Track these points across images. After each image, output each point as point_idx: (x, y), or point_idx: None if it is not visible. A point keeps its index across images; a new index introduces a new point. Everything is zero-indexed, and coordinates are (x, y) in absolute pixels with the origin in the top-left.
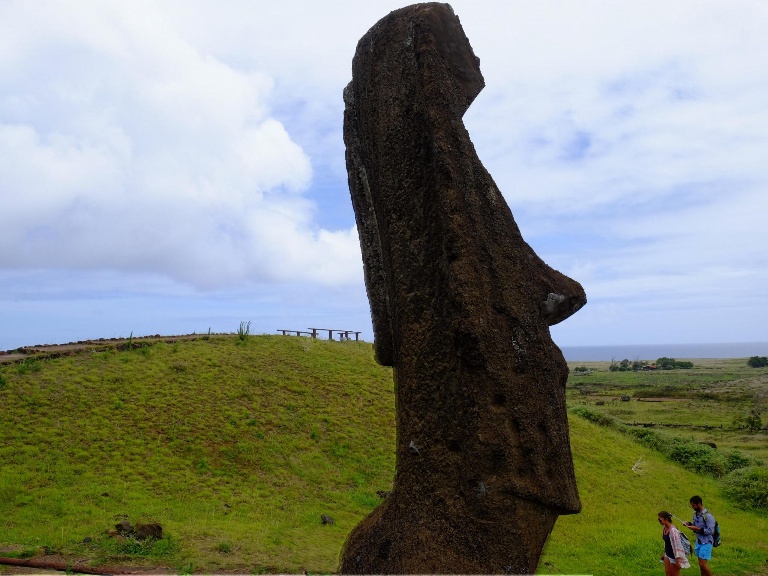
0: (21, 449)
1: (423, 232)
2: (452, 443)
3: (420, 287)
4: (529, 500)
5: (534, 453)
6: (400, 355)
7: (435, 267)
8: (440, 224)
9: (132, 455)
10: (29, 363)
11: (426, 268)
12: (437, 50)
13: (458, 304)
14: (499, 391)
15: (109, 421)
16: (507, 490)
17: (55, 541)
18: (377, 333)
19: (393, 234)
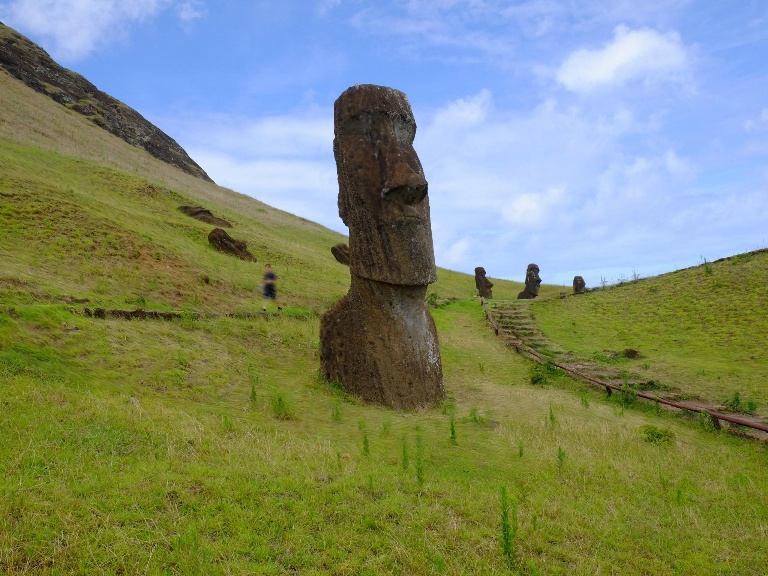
0: (675, 313)
1: None
2: None
3: None
4: None
5: None
6: None
7: None
8: None
9: (743, 321)
10: (742, 256)
11: None
12: (335, 115)
13: None
14: None
15: (758, 297)
16: None
17: (584, 351)
18: None
19: None
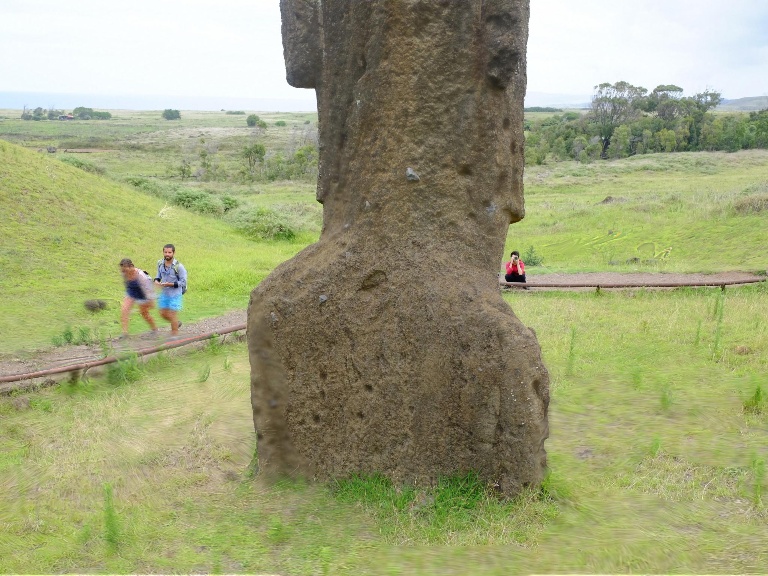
0: None
1: None
2: (464, 167)
3: None
4: (512, 215)
5: (518, 173)
6: (383, 73)
7: None
8: None
9: None
10: None
11: None
12: None
13: (509, 19)
14: (507, 115)
15: None
16: (508, 207)
17: None
18: (303, 45)
19: None
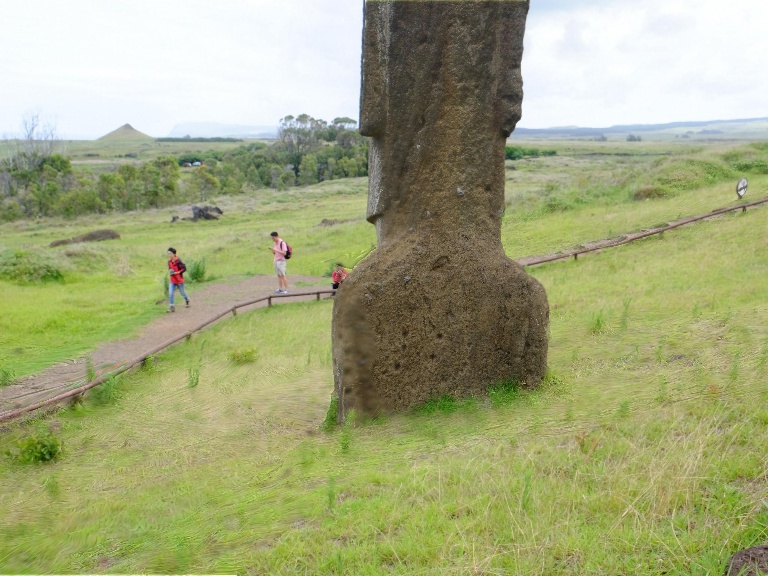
0: None
1: (481, 41)
2: (487, 186)
3: (468, 80)
4: None
5: None
6: (440, 128)
7: (484, 68)
8: (495, 39)
9: None
10: None
11: (477, 67)
12: None
13: (517, 98)
14: None
15: None
16: None
17: None
18: (377, 108)
19: (454, 35)
